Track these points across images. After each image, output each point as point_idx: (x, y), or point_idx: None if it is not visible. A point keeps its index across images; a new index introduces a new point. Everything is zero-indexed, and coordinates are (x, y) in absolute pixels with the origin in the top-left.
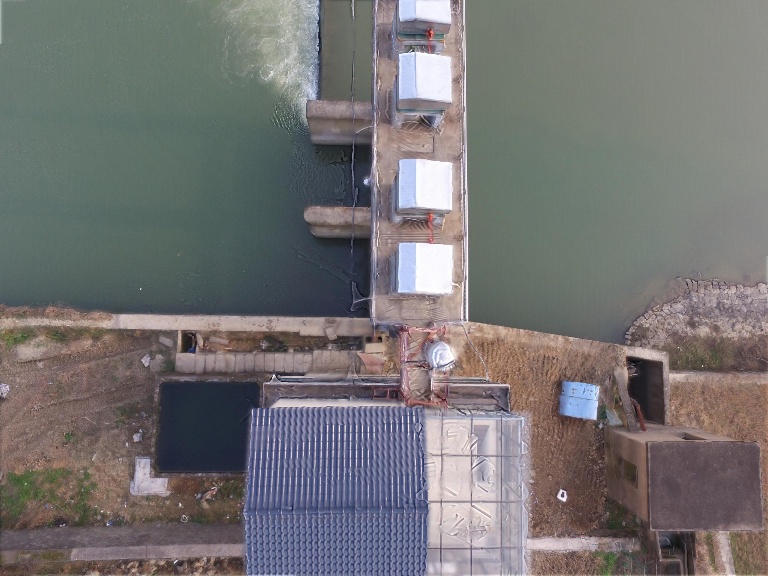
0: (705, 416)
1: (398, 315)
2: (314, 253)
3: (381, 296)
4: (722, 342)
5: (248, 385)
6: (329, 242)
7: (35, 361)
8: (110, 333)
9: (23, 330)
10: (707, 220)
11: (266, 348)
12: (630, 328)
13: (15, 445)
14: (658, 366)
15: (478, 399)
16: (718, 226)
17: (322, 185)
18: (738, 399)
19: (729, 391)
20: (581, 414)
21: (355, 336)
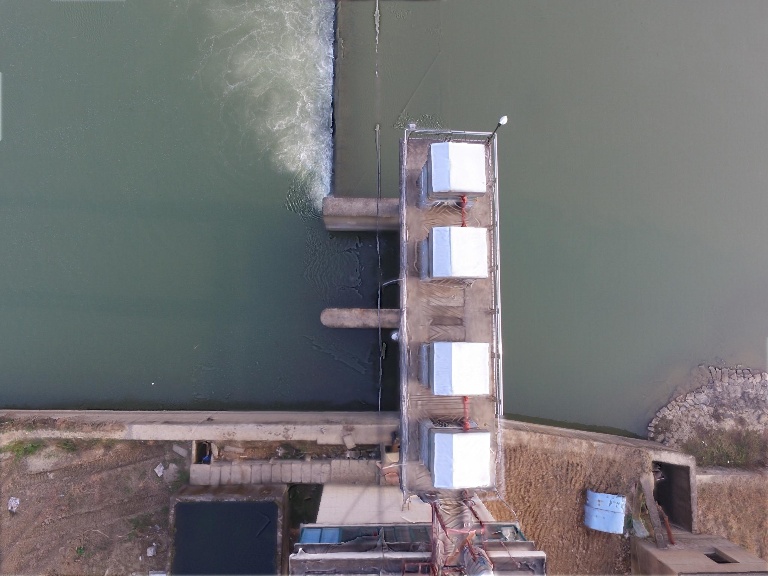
0: (733, 520)
1: (429, 482)
2: (329, 343)
3: (411, 463)
4: (748, 436)
5: (265, 504)
6: (344, 331)
7: (46, 472)
8: (122, 442)
9: (33, 441)
10: (730, 304)
11: (282, 455)
12: (653, 420)
13: (26, 562)
14: (685, 470)
15: (513, 571)
16: (741, 310)
17: (337, 272)
18: (766, 501)
19: (757, 493)
20: (607, 528)
21: (374, 444)
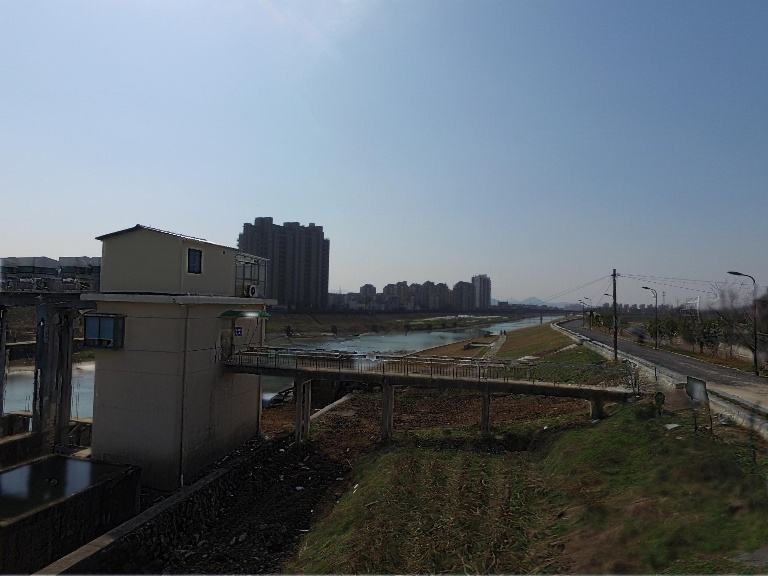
0: None
1: None
2: None
3: None
4: None
5: (42, 463)
6: None
7: None
8: None
9: None
10: None
11: None
12: None
13: None
14: None
15: None
16: None
17: None
18: None
19: None
20: (274, 395)
21: None
